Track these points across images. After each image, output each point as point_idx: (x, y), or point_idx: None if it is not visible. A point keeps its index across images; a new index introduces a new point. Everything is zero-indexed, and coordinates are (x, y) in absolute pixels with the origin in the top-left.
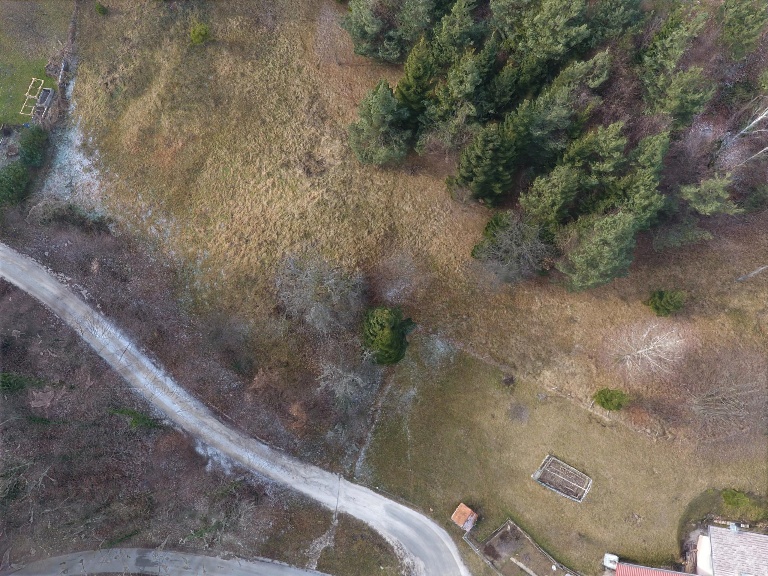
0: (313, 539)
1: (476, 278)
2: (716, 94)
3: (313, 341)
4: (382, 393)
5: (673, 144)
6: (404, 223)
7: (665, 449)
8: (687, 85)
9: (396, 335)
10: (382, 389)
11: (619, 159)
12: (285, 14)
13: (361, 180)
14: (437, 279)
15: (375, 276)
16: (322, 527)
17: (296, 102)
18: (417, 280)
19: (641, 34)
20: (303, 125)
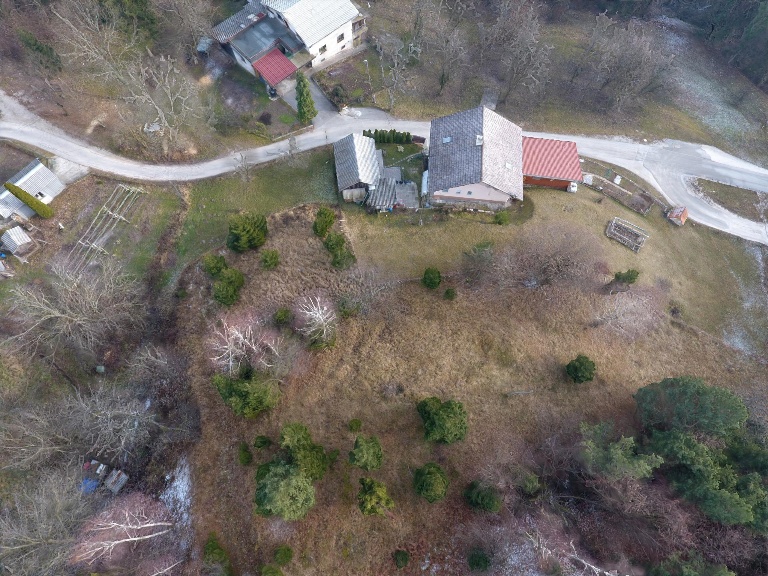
0: None
1: None
2: None
3: None
4: None
5: (698, 522)
6: None
7: None
8: None
9: None
10: None
11: None
12: None
13: None
14: None
15: None
16: None
17: None
18: None
19: None
20: None
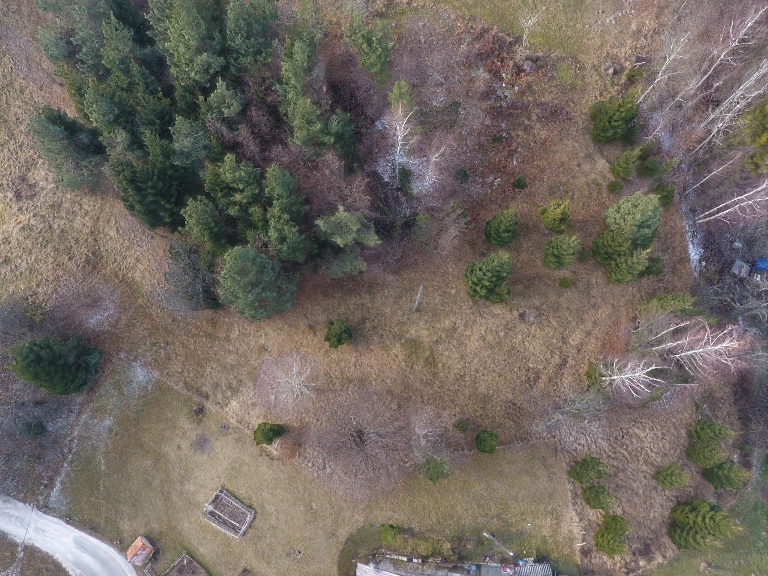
0: (1, 571)
1: (178, 305)
2: (411, 118)
3: (2, 370)
4: (78, 422)
5: (305, 175)
6: (109, 248)
7: (324, 484)
8: (309, 115)
9: (45, 368)
10: (78, 418)
11: (252, 190)
12: (11, 34)
13: (70, 204)
14: (141, 306)
15: (75, 303)
16: (9, 559)
17: (16, 124)
18: (121, 307)
19: (271, 62)
20: (22, 147)
